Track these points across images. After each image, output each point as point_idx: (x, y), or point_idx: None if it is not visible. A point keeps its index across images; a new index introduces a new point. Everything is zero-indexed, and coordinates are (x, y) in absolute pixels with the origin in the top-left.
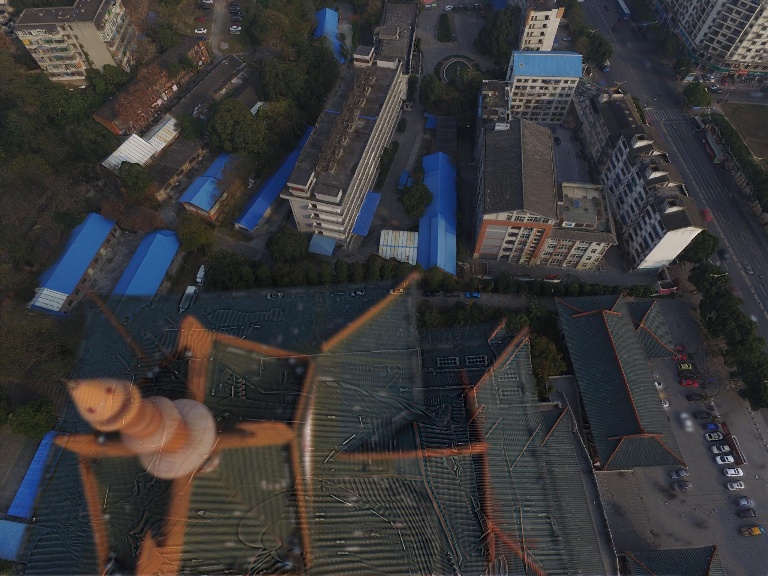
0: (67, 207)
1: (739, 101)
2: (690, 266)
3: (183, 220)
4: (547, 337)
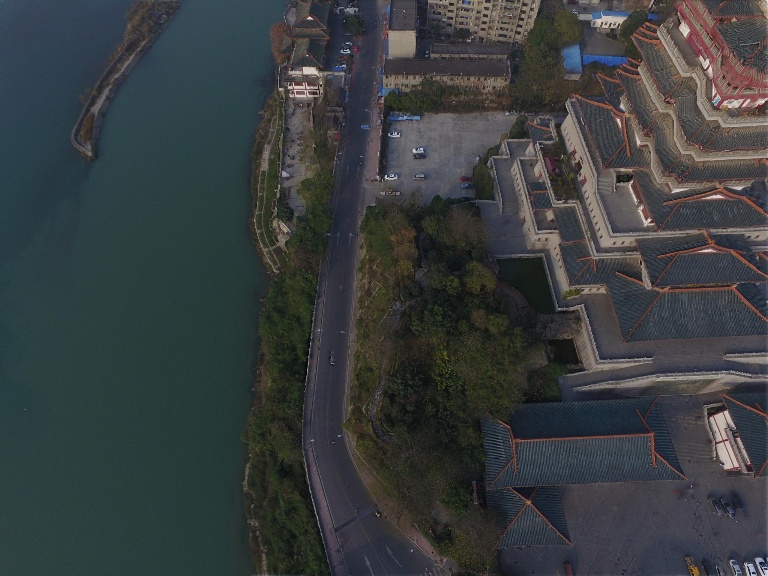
0: None
1: None
2: None
3: None
4: None
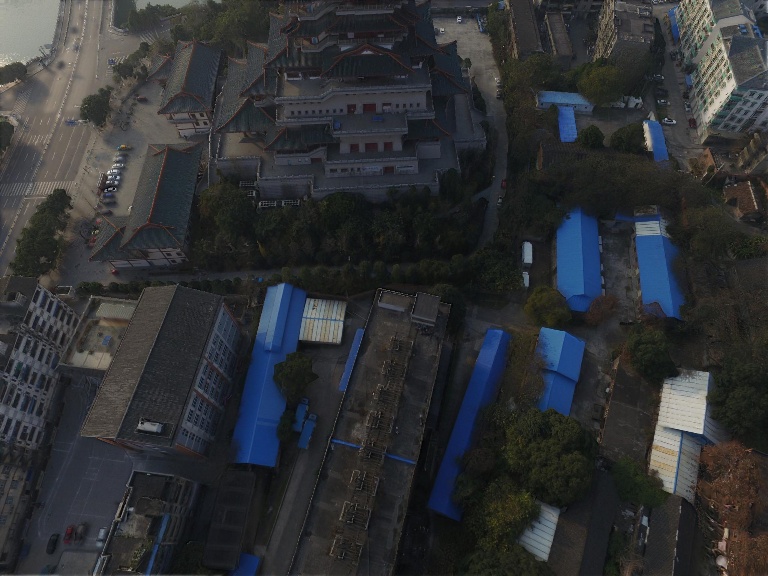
0: None
1: None
2: None
3: (560, 301)
4: (202, 236)
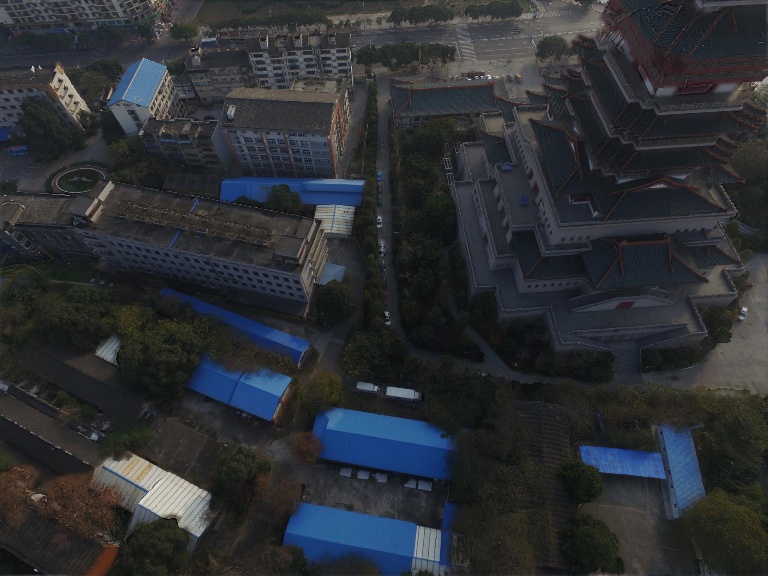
0: (288, 557)
1: (192, 17)
2: (353, 65)
3: (313, 394)
4: None
